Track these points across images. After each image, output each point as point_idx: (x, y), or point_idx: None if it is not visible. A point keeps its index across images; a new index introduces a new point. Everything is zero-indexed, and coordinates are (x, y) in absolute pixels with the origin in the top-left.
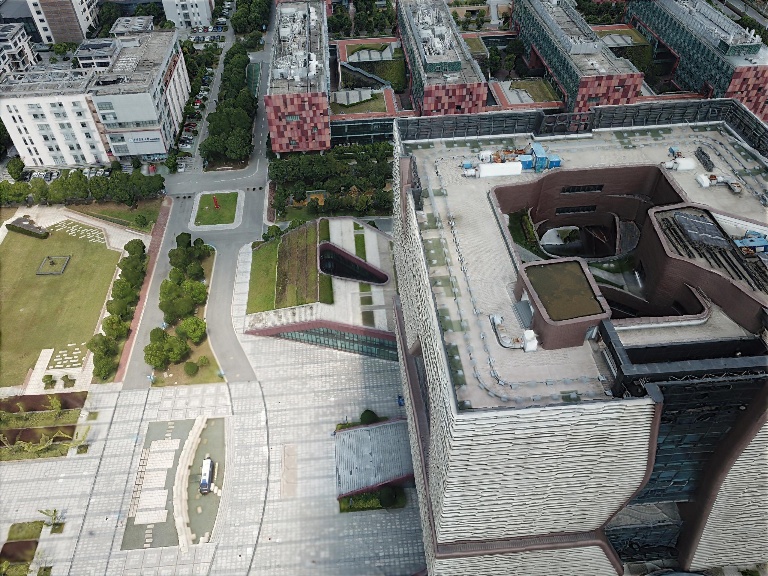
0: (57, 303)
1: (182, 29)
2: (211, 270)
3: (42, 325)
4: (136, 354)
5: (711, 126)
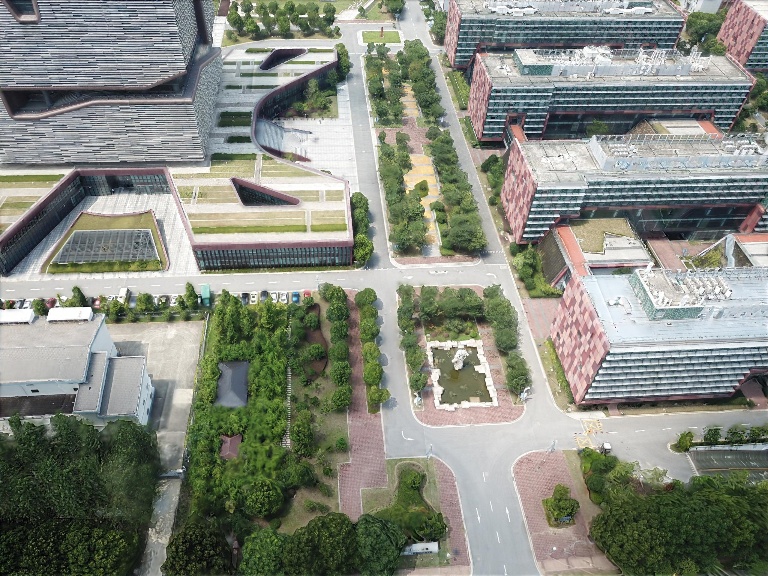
0: (295, 3)
1: (681, 7)
2: (315, 39)
3: None
4: None
5: None
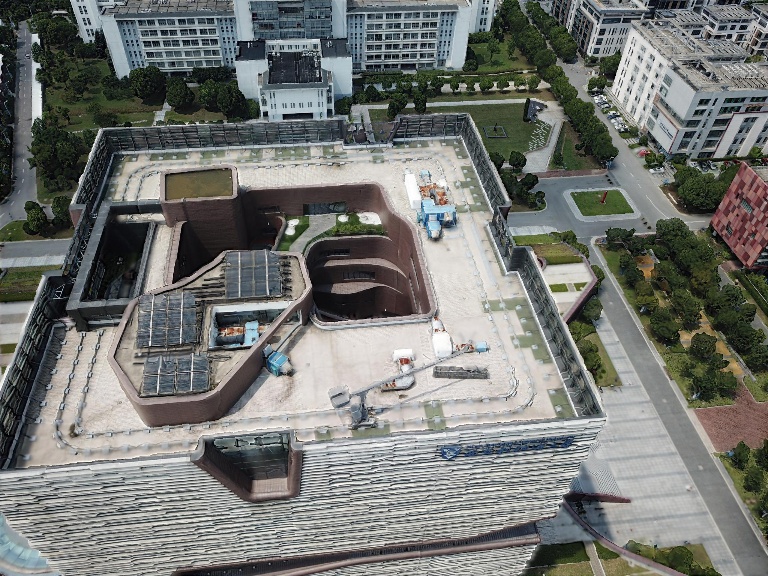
0: None
1: None
2: (512, 211)
3: None
4: None
5: (571, 416)
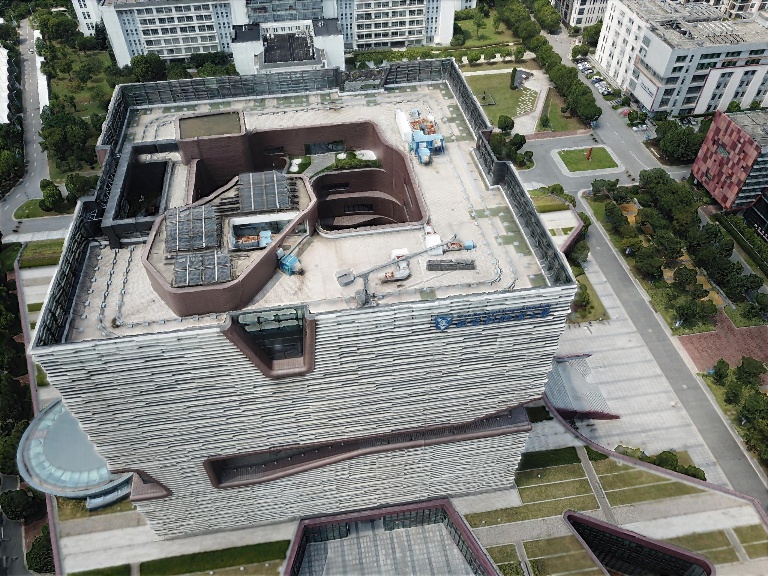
0: None
1: None
2: None
3: None
4: None
5: None
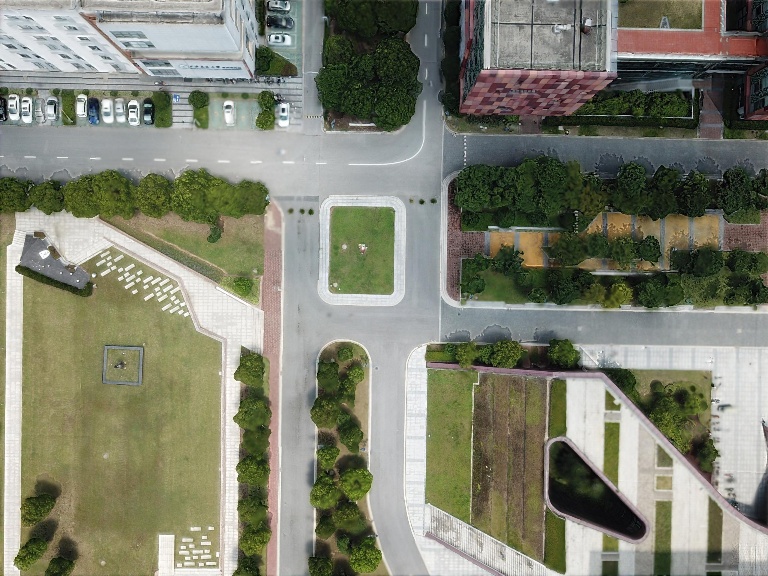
0: (153, 448)
1: None
2: (367, 406)
3: (144, 489)
4: (285, 555)
5: None
